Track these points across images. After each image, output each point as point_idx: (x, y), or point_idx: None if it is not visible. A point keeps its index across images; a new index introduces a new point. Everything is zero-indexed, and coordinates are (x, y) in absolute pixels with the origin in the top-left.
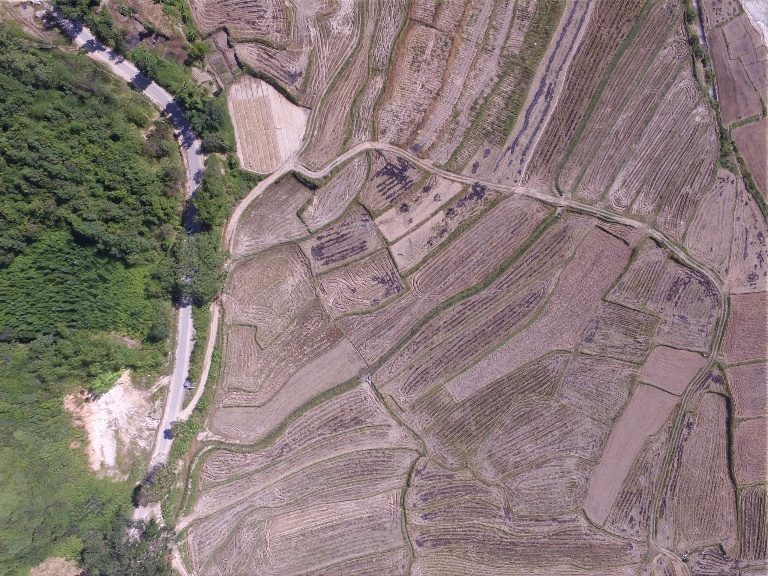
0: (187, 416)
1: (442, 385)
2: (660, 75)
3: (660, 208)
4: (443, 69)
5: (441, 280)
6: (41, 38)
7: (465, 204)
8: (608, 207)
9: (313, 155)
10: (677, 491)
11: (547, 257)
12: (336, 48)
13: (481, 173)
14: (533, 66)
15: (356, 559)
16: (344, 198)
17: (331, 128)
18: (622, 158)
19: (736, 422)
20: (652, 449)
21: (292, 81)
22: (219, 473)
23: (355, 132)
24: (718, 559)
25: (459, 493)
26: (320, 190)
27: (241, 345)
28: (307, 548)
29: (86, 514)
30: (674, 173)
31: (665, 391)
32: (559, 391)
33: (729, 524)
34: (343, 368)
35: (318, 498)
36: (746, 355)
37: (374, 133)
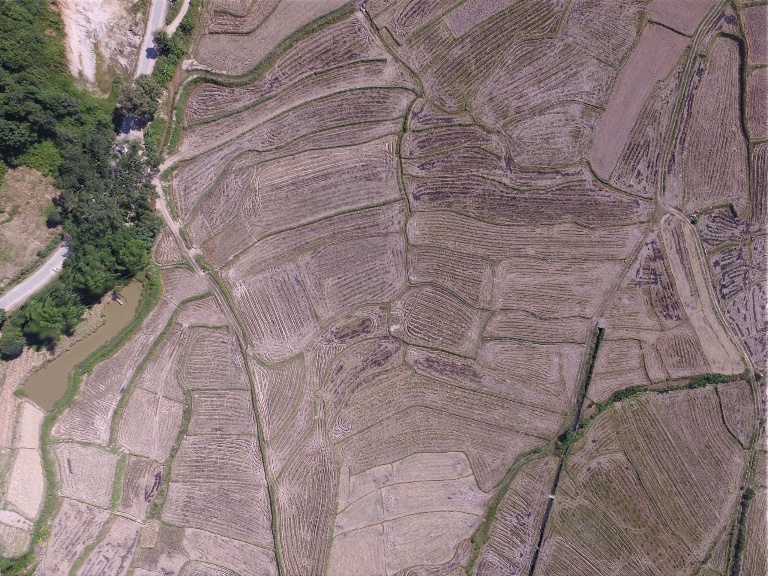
0: (171, 34)
1: (440, 18)
2: None
3: None
4: None
5: None
6: None
7: None
8: None
9: None
10: (686, 145)
11: None
12: None
13: None
14: None
15: (350, 213)
16: None
17: None
18: None
19: (749, 68)
20: (661, 96)
21: None
22: (205, 109)
23: None
24: (728, 222)
25: (458, 140)
26: None
27: None
28: (298, 198)
29: (63, 114)
30: None
31: (675, 31)
32: (563, 28)
33: (740, 183)
34: None
35: (310, 142)
36: None
37: None
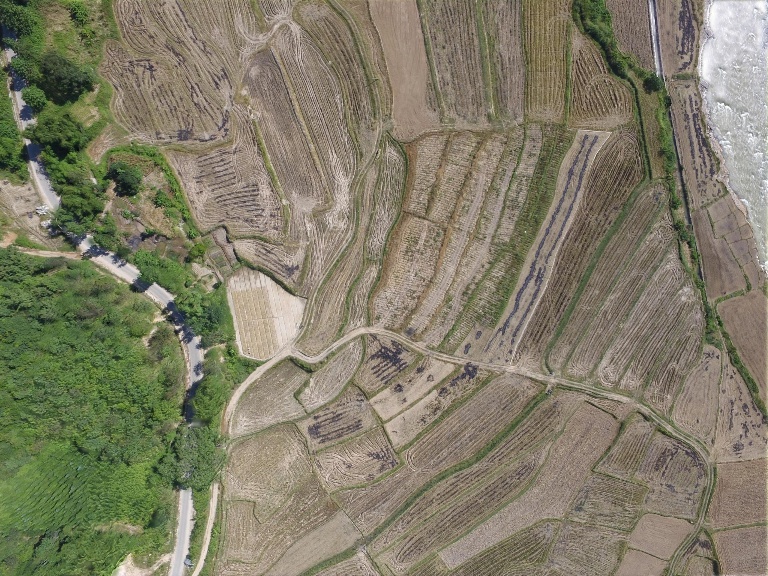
0: None
1: (436, 553)
2: (647, 258)
3: (647, 384)
4: (436, 258)
5: (434, 455)
6: (46, 246)
7: (457, 383)
8: (597, 383)
9: (310, 341)
10: None
11: (537, 431)
12: (332, 242)
13: (473, 354)
14: (523, 252)
15: None
16: (340, 380)
17: (327, 316)
18: (610, 337)
19: None
20: None
21: (289, 274)
22: None
23: (350, 318)
24: None
25: None
26: (316, 373)
27: (240, 519)
28: None
29: None
30: (661, 350)
31: (653, 556)
32: (550, 557)
33: None
34: (339, 539)
35: None
36: (732, 521)
37: (369, 319)
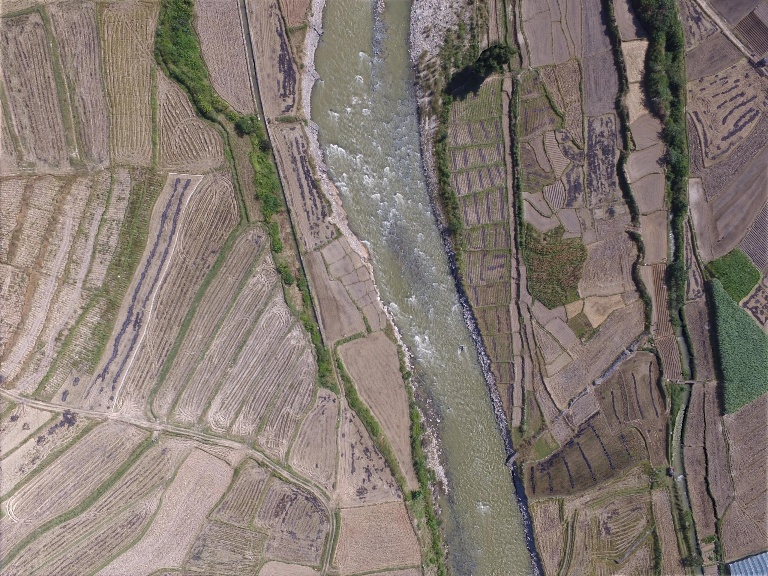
0: None
1: None
2: (251, 302)
3: (260, 429)
4: (22, 304)
5: (37, 505)
6: None
7: (56, 432)
8: (206, 429)
9: None
10: None
11: (147, 479)
12: None
13: (71, 401)
14: (118, 297)
15: None
16: None
17: None
18: (218, 382)
19: None
20: None
21: None
22: None
23: None
24: None
25: None
26: None
27: None
28: None
29: None
30: (273, 394)
31: None
32: None
33: None
34: None
35: None
36: (360, 567)
37: None
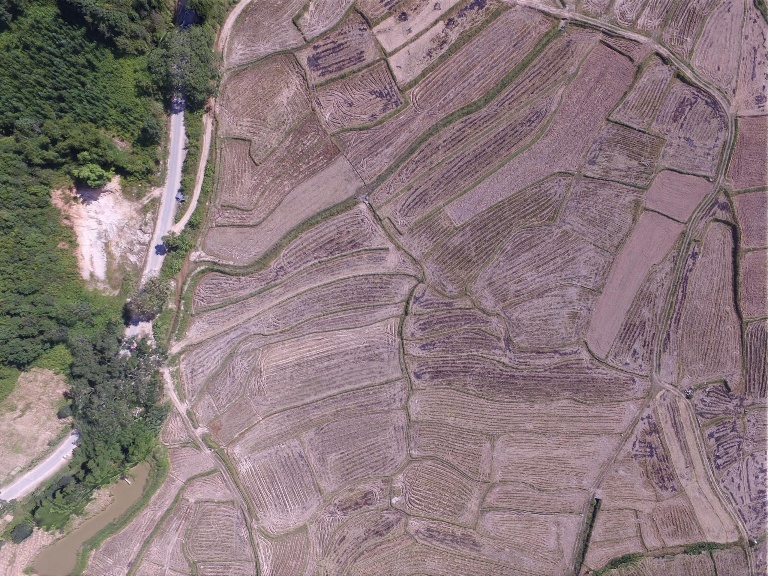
0: (179, 231)
1: (441, 208)
2: None
3: (666, 23)
4: None
5: (441, 95)
6: None
7: (466, 14)
8: (613, 21)
9: None
10: (681, 324)
11: (550, 73)
12: None
13: None
14: None
15: (353, 391)
16: (341, 4)
17: None
18: None
19: (742, 252)
20: (656, 279)
21: None
22: (212, 297)
23: None
24: (722, 397)
25: (458, 323)
26: None
27: (235, 160)
28: (302, 379)
29: (75, 320)
30: None
31: (670, 218)
32: (561, 216)
33: (734, 359)
34: (340, 187)
35: (314, 326)
36: (753, 181)
37: None
